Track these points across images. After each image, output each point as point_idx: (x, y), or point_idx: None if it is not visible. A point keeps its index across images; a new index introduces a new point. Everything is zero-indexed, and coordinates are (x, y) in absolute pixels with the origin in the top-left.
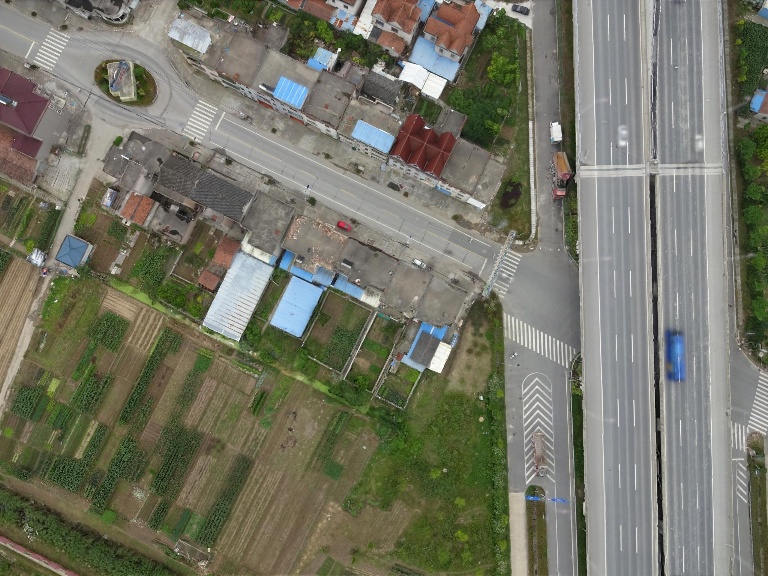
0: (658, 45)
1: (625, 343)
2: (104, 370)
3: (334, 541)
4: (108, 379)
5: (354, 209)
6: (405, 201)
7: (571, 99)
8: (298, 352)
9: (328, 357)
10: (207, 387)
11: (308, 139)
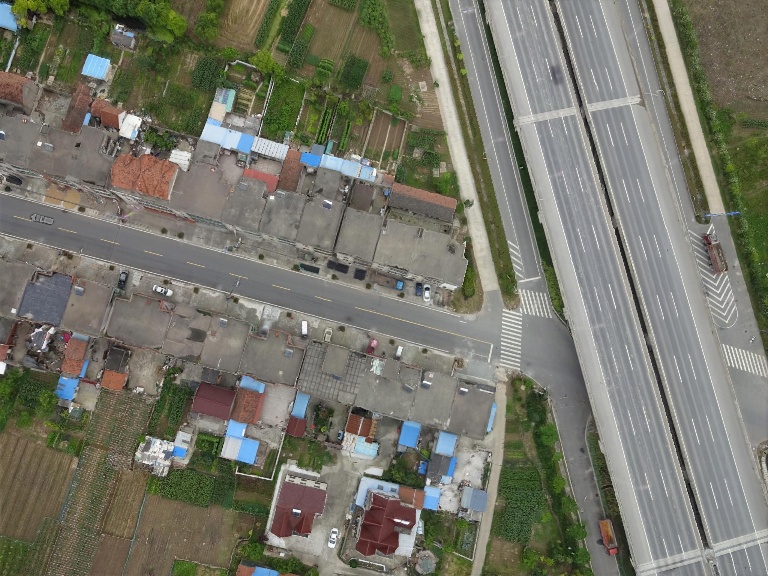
0: None
1: (686, 373)
2: None
3: None
4: None
5: None
6: None
7: None
8: None
9: None
10: None
11: None
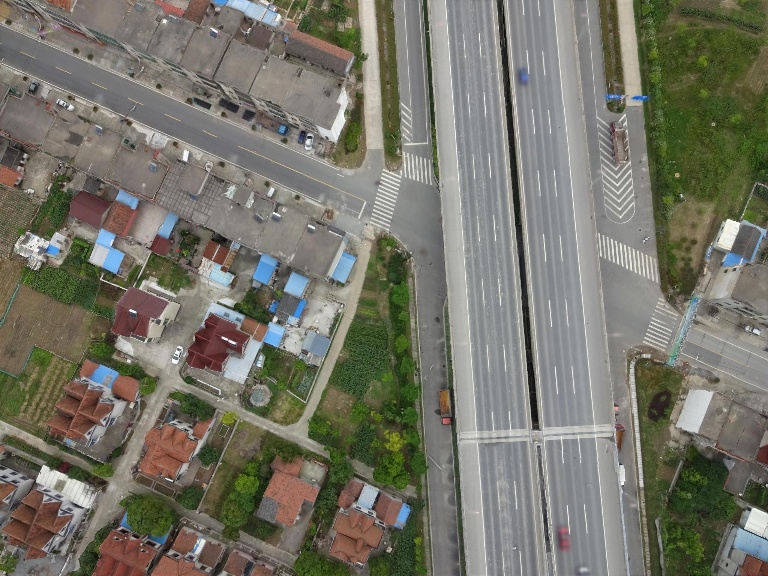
0: (549, 572)
1: (553, 253)
2: None
3: None
4: None
5: None
6: None
7: None
8: None
9: None
10: None
11: None
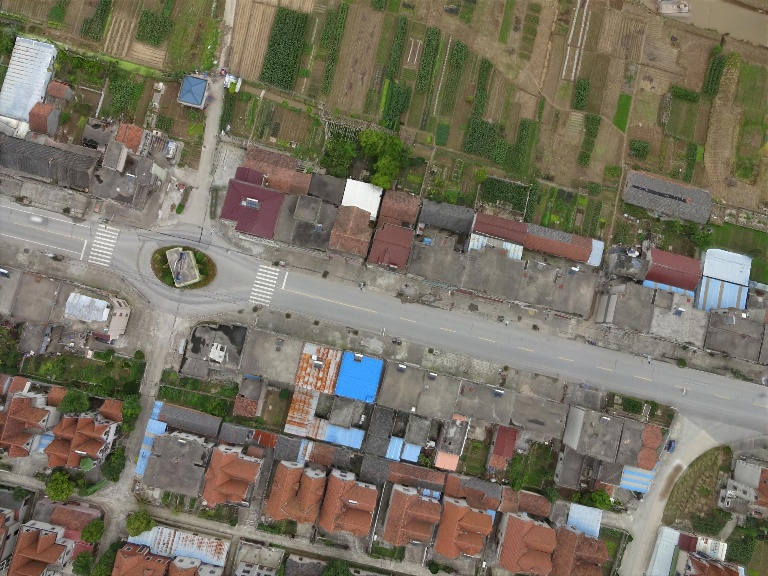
0: None
1: None
2: None
3: None
4: None
5: None
6: None
7: None
8: None
9: None
10: None
11: None
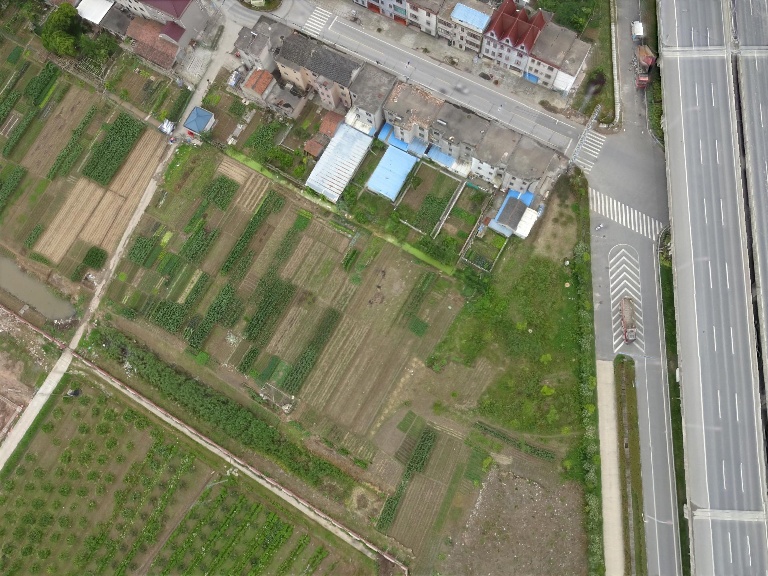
0: None
1: (714, 207)
2: (213, 226)
3: (416, 396)
4: (216, 232)
5: (447, 94)
6: (495, 88)
7: (651, 5)
8: (390, 214)
9: (418, 221)
10: (304, 244)
11: (409, 37)
